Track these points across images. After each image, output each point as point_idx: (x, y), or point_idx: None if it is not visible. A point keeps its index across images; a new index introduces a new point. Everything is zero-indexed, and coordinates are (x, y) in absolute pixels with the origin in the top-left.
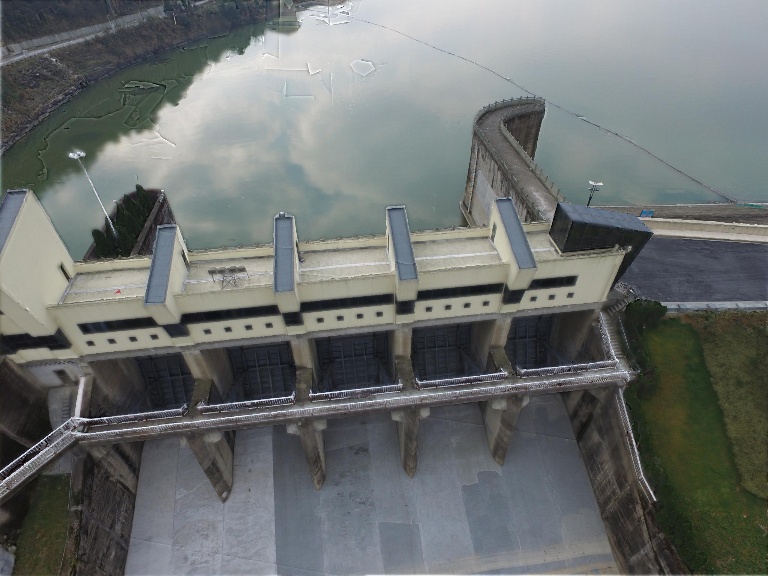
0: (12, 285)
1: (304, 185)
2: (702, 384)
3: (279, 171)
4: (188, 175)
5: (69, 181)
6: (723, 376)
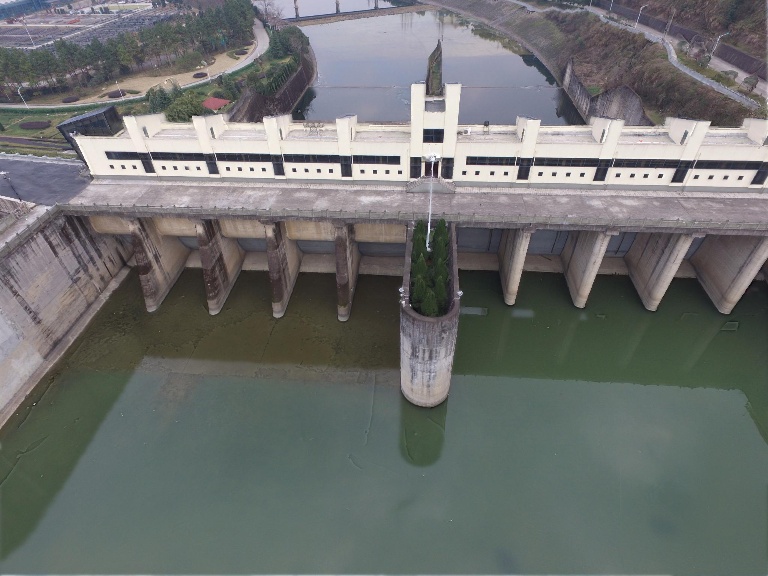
0: None
1: None
2: None
3: None
4: None
5: None
6: None
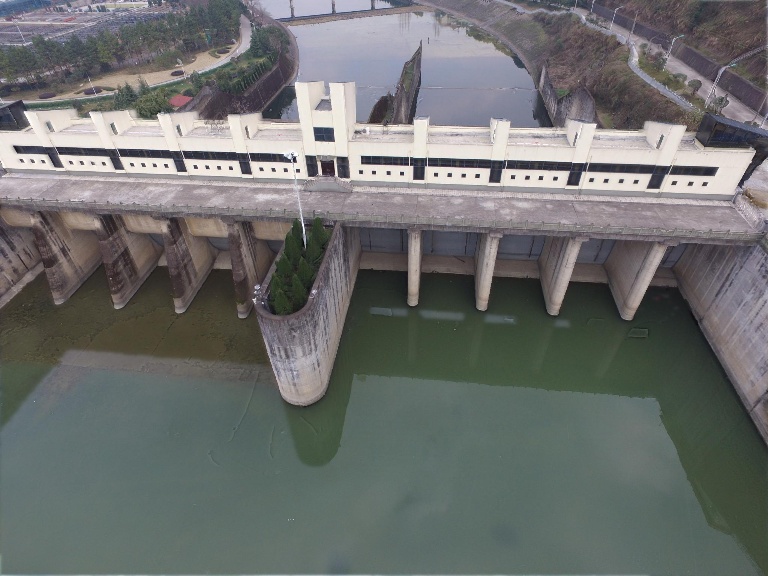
0: None
1: None
2: None
3: None
4: None
5: None
6: None
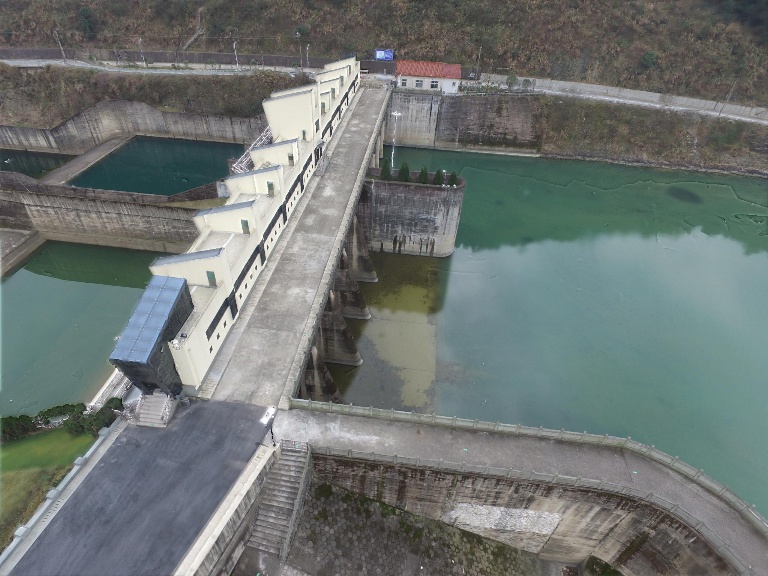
0: (270, 112)
1: (618, 339)
2: (31, 468)
3: (649, 319)
4: (622, 254)
5: (596, 197)
6: (12, 481)
